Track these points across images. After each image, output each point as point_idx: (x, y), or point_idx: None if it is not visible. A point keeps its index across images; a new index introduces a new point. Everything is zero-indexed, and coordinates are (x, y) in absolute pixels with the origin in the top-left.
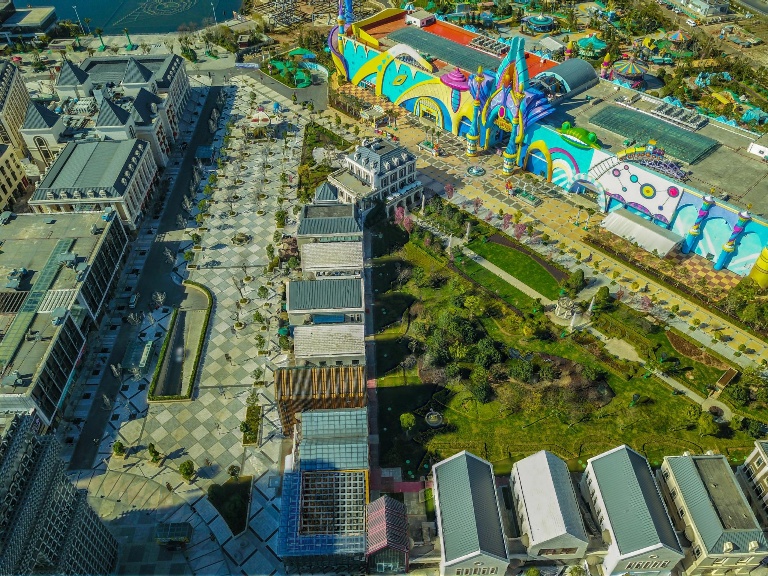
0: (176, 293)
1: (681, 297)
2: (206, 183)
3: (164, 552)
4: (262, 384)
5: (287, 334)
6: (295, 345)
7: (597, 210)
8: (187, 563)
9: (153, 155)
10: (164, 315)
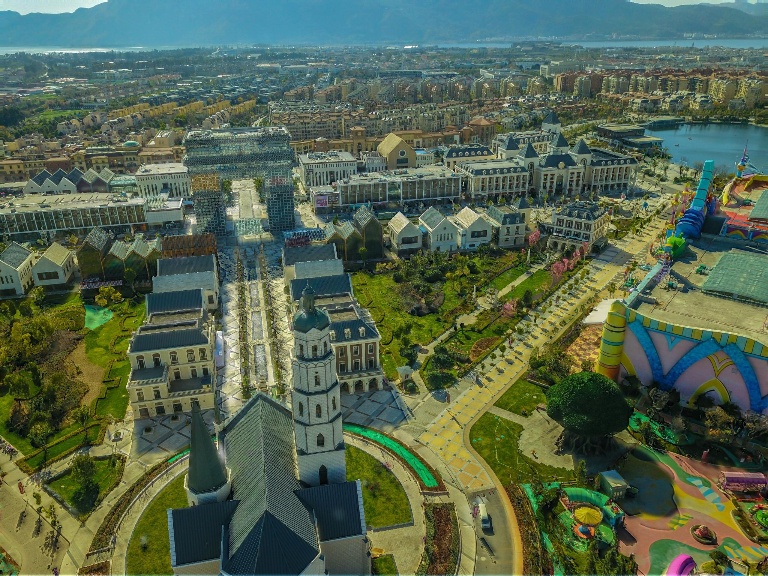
0: None
1: None
2: None
3: None
4: None
5: None
6: None
7: None
8: None
9: None
10: None
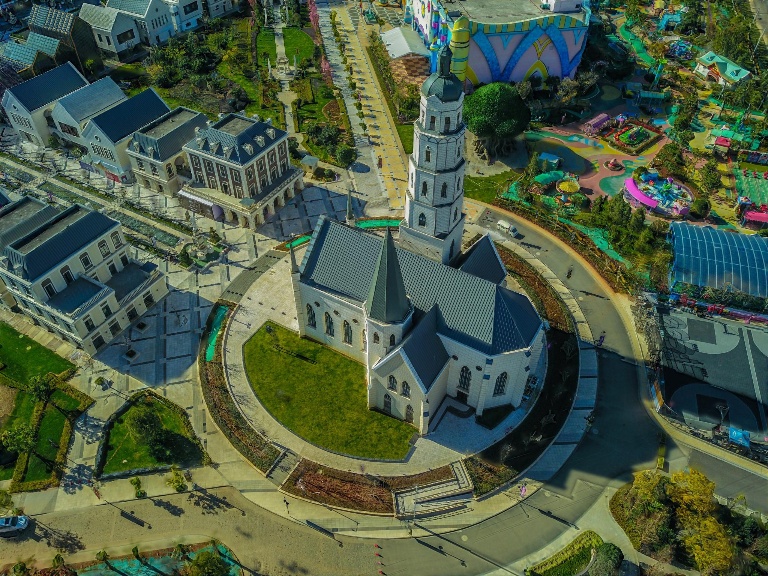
0: None
1: (380, 90)
2: None
3: None
4: None
5: None
6: (79, 14)
7: None
8: None
9: None
10: None
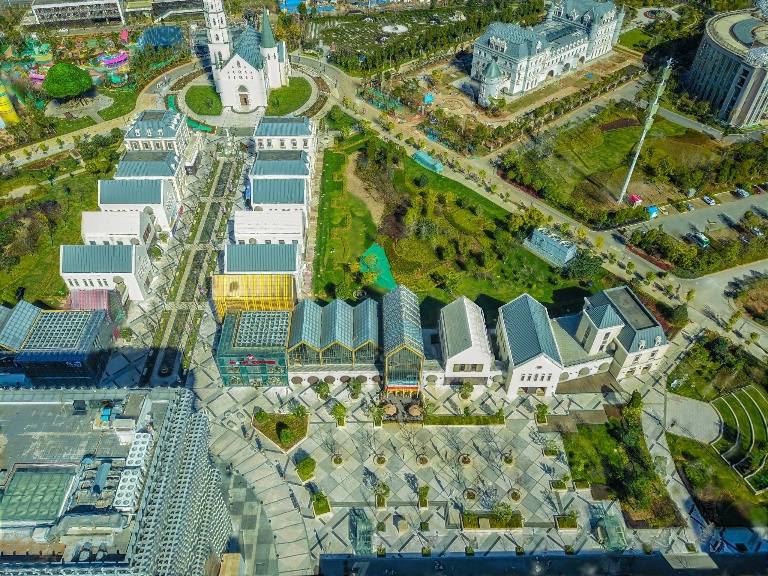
0: None
1: None
2: None
3: None
4: None
5: None
6: None
7: None
8: None
9: None
10: None
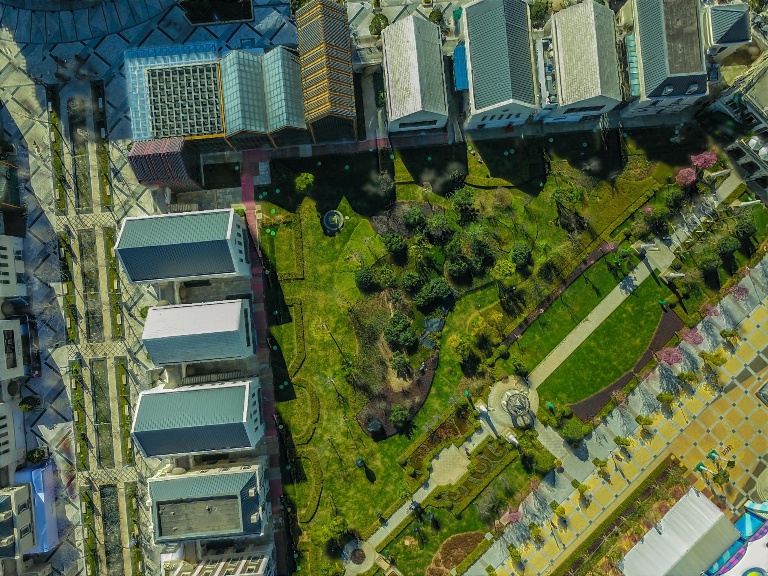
0: None
1: (550, 572)
2: None
3: None
4: (375, 5)
5: (456, 22)
6: (394, 24)
7: (752, 496)
8: None
9: None
10: None
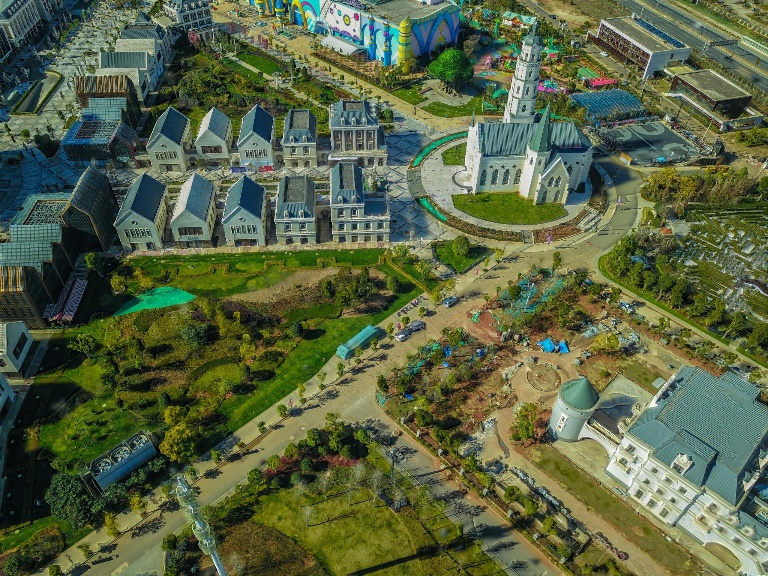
0: (40, 76)
1: (354, 77)
2: (75, 29)
3: (7, 165)
4: None
5: None
6: None
7: None
8: (18, 168)
9: (38, 11)
10: (29, 85)
